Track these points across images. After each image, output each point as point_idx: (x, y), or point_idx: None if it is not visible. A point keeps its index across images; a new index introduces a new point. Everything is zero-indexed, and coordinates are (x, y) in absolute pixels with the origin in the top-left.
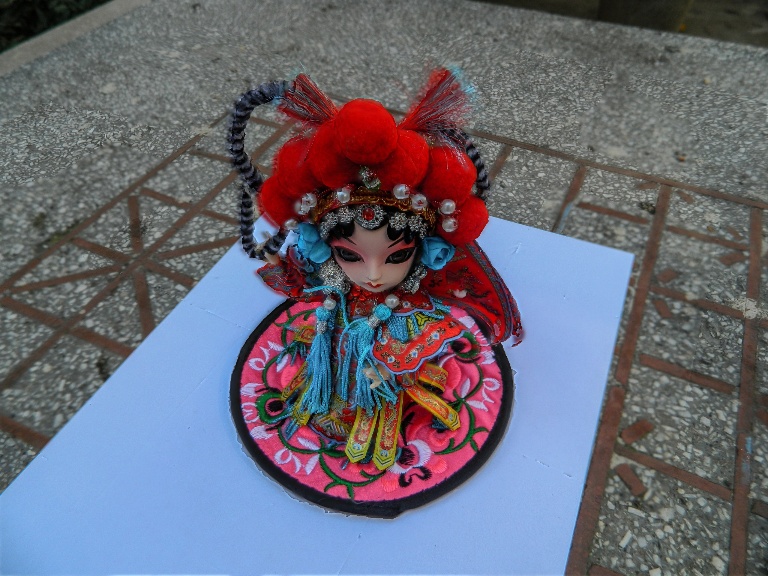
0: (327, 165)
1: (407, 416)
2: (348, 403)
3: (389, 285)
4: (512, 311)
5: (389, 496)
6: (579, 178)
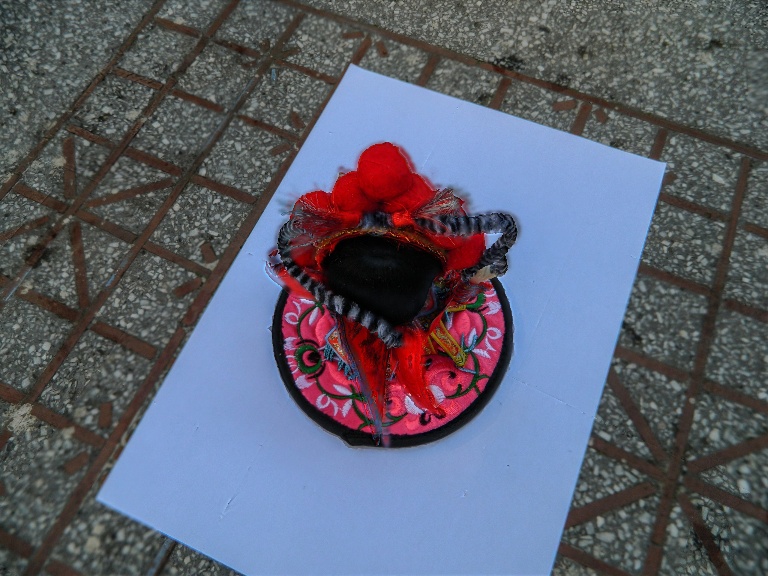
0: None
1: None
2: None
3: None
4: None
5: None
6: None
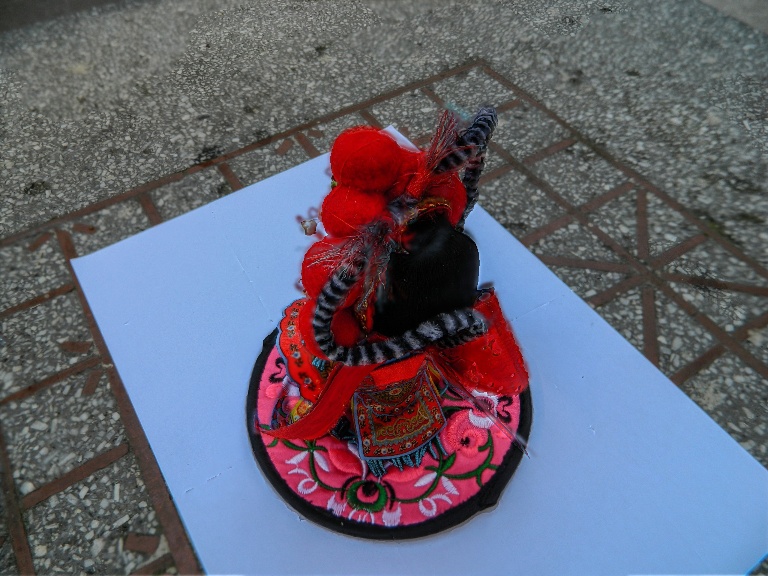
0: None
1: None
2: None
3: None
4: None
5: None
6: None
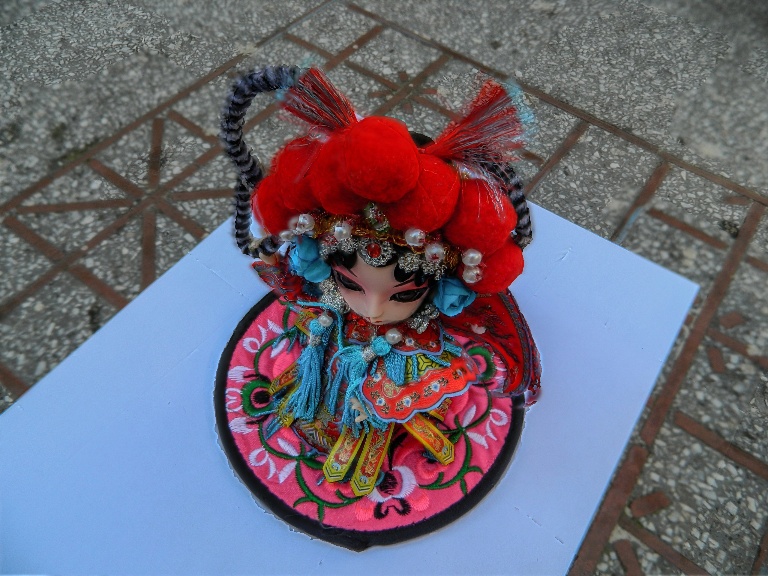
0: (328, 191)
1: (399, 436)
2: (335, 417)
3: None
4: (533, 364)
5: (360, 526)
6: (658, 177)
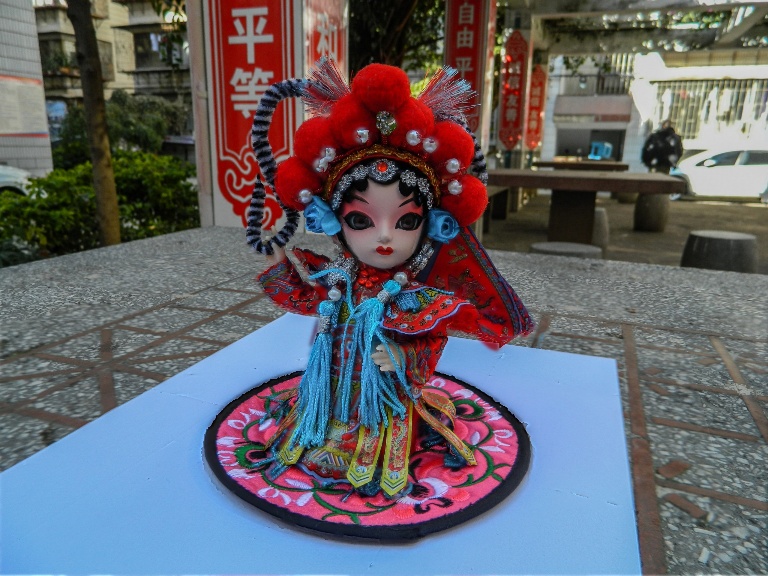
0: (348, 113)
1: (414, 461)
2: (348, 426)
3: (398, 259)
4: (518, 309)
5: (404, 521)
6: (546, 321)
